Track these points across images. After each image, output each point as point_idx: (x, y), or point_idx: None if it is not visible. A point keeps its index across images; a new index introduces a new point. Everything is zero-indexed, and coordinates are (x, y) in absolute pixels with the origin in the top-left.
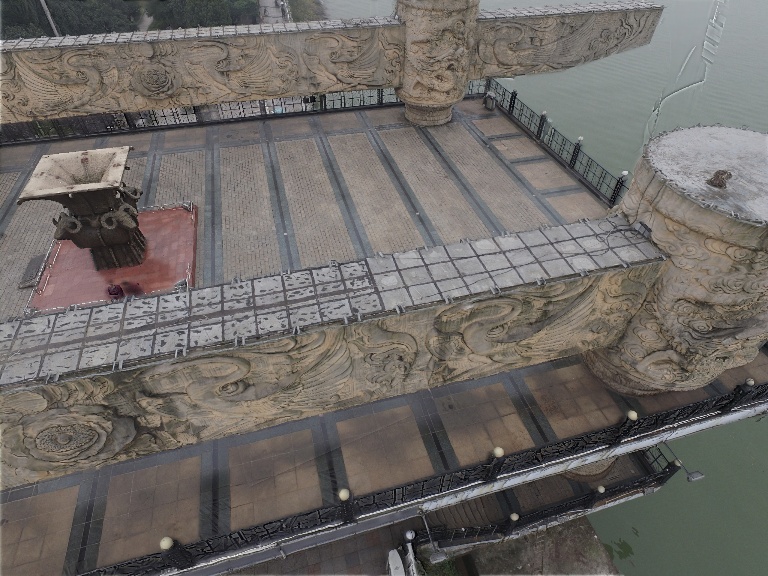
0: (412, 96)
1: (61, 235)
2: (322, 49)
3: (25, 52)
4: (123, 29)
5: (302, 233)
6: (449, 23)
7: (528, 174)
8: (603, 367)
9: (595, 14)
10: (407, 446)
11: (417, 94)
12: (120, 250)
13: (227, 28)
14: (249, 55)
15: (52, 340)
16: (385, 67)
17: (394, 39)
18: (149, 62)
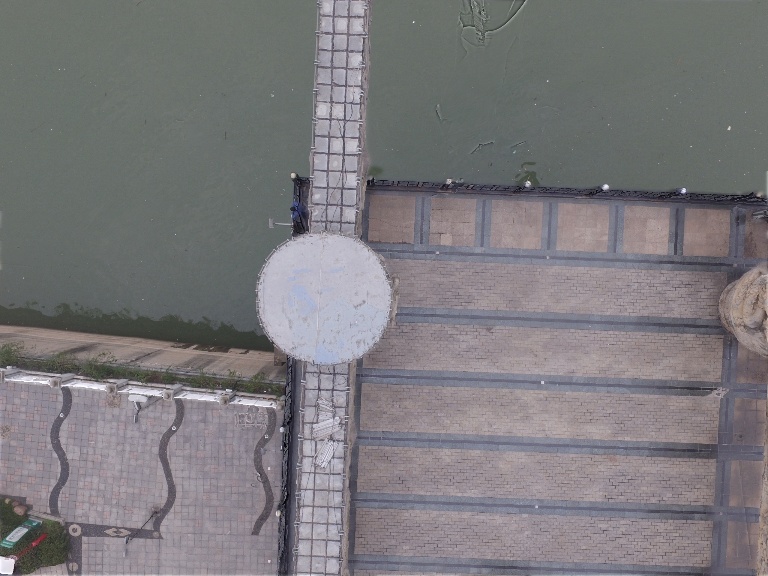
0: None
1: None
2: None
3: None
4: None
5: (540, 493)
6: (394, 305)
7: (509, 242)
8: None
9: None
10: (756, 471)
11: None
12: None
13: None
14: None
15: None
16: None
17: (351, 367)
18: None
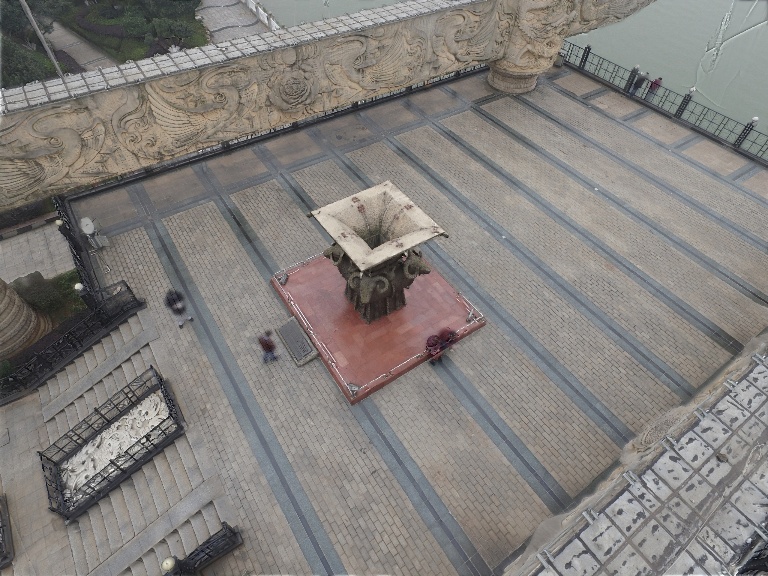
0: (517, 66)
1: (370, 298)
2: (449, 28)
3: (160, 80)
4: (54, 12)
5: (518, 233)
6: None
7: (647, 130)
8: None
9: None
10: None
11: (524, 63)
12: None
13: (355, 16)
14: (385, 46)
15: (765, 422)
16: (496, 39)
17: (509, 8)
18: (289, 70)
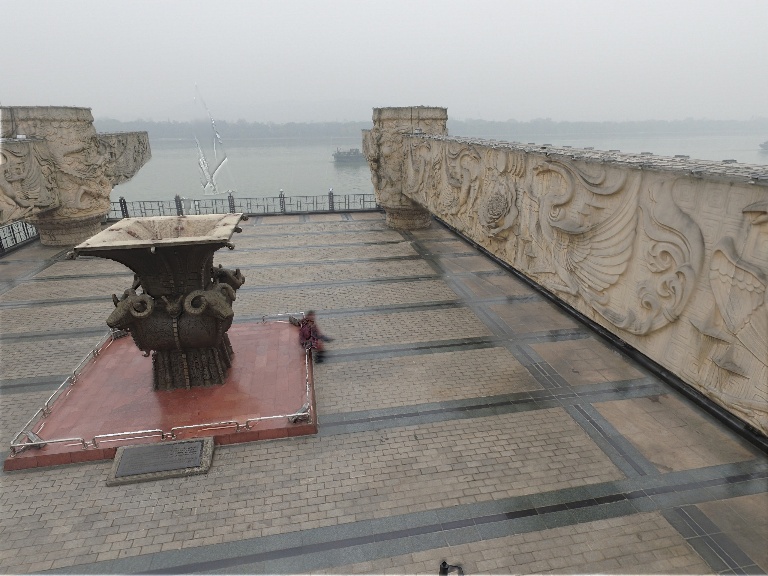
0: (81, 209)
1: None
2: None
3: None
4: None
5: None
6: (93, 132)
7: None
8: (419, 220)
9: (128, 135)
10: None
11: (87, 205)
12: None
13: None
14: None
15: None
16: (45, 185)
17: (43, 154)
18: None
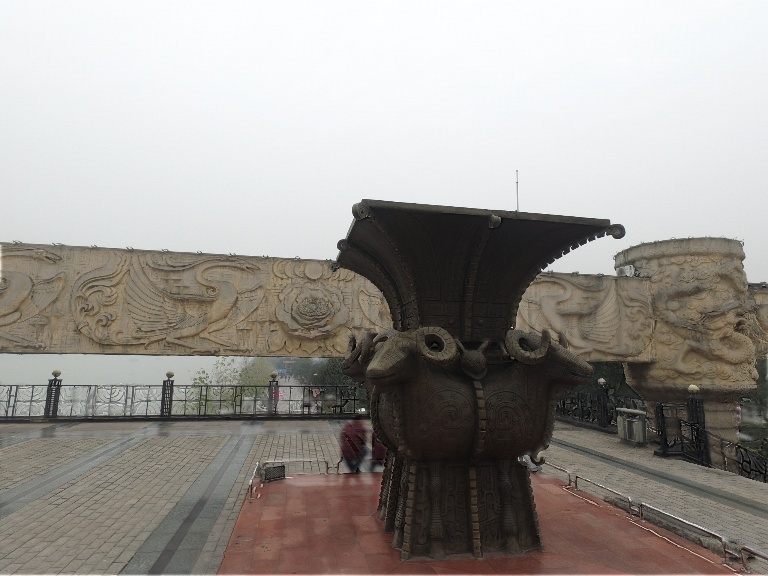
0: None
1: None
2: None
3: None
4: None
5: None
6: None
7: None
8: None
9: None
10: (86, 427)
11: None
12: None
13: None
14: None
15: None
16: None
17: None
18: None
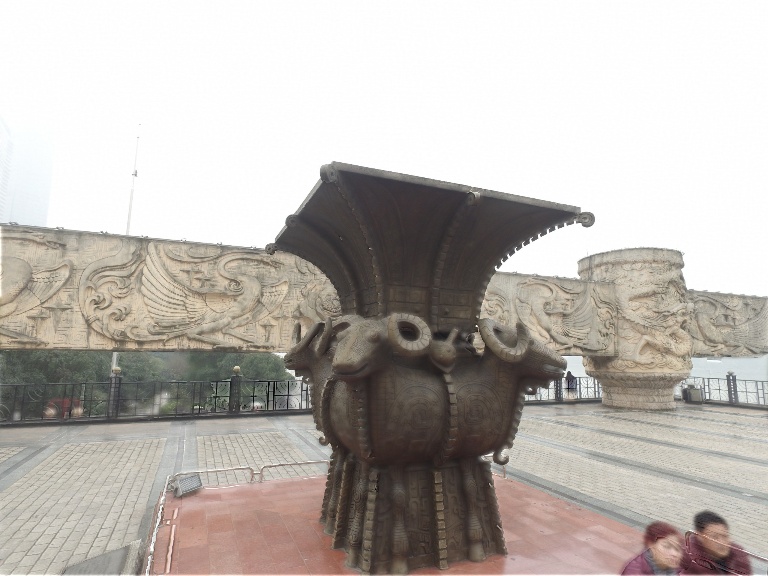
0: (639, 364)
1: (363, 356)
2: (535, 297)
3: (170, 244)
4: None
5: None
6: (674, 274)
7: None
8: None
9: (767, 300)
10: None
11: (648, 359)
12: (454, 487)
13: None
14: None
15: None
16: (599, 328)
17: (605, 297)
18: None
